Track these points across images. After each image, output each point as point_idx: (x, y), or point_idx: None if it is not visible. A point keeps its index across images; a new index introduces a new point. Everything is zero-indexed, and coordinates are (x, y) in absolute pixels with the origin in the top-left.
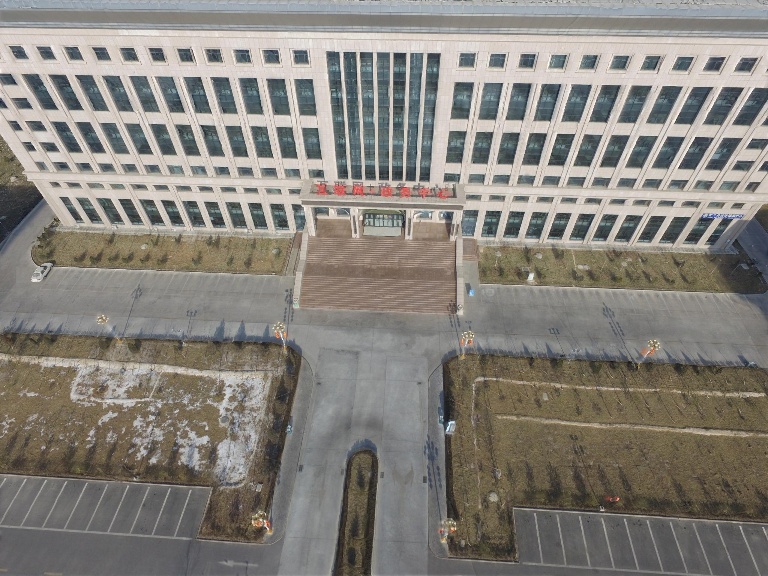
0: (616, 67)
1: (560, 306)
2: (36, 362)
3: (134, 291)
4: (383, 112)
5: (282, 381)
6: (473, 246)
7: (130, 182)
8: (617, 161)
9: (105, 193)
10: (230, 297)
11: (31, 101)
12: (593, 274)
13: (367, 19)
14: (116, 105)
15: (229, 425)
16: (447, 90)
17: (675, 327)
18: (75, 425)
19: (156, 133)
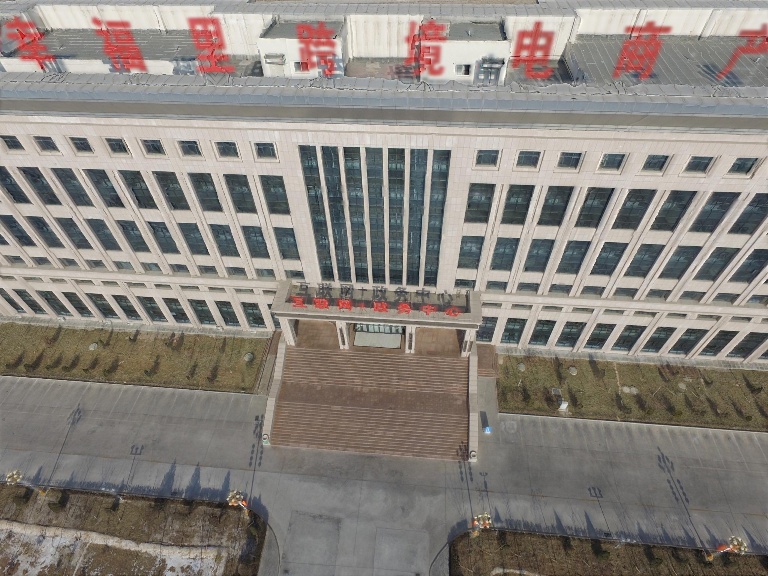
0: (692, 169)
1: (602, 451)
2: None
3: (72, 413)
4: (376, 213)
5: None
6: (490, 356)
7: (71, 277)
8: (682, 273)
9: (45, 286)
10: (187, 426)
11: None
12: (643, 401)
13: (349, 112)
14: (41, 198)
15: None
16: (460, 191)
17: (756, 491)
18: None
19: (94, 228)
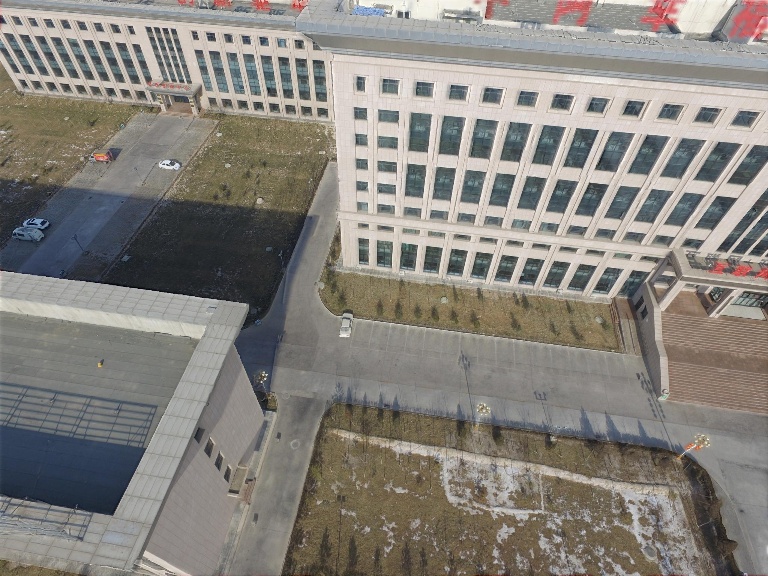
0: None
1: None
2: (387, 446)
3: (460, 359)
4: None
5: (696, 503)
6: None
7: (457, 232)
8: None
9: (416, 239)
10: (575, 378)
11: (401, 141)
12: None
13: None
14: None
15: (658, 560)
16: None
17: None
18: (471, 540)
19: (526, 186)
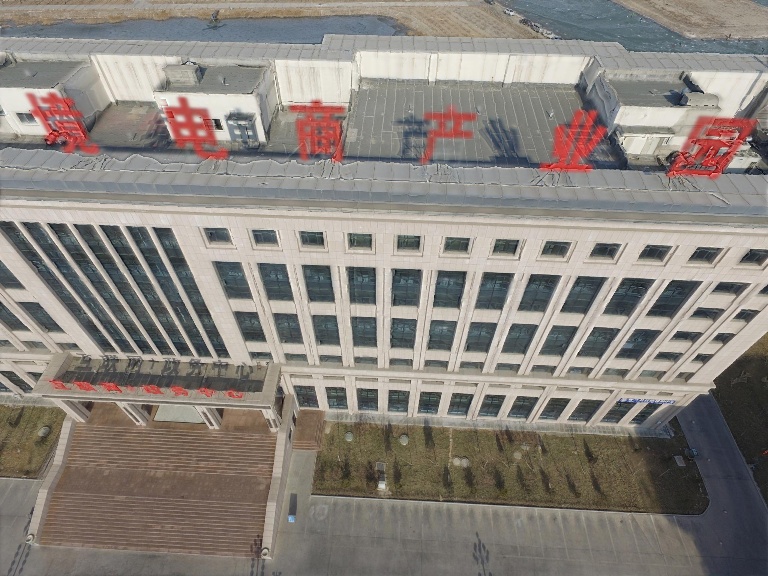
0: (455, 248)
1: (414, 540)
2: None
3: None
4: (126, 288)
5: None
6: (316, 424)
7: None
8: (488, 347)
9: None
10: None
11: None
12: (472, 475)
13: (13, 192)
14: None
15: None
16: (205, 269)
17: None
18: None
19: None
